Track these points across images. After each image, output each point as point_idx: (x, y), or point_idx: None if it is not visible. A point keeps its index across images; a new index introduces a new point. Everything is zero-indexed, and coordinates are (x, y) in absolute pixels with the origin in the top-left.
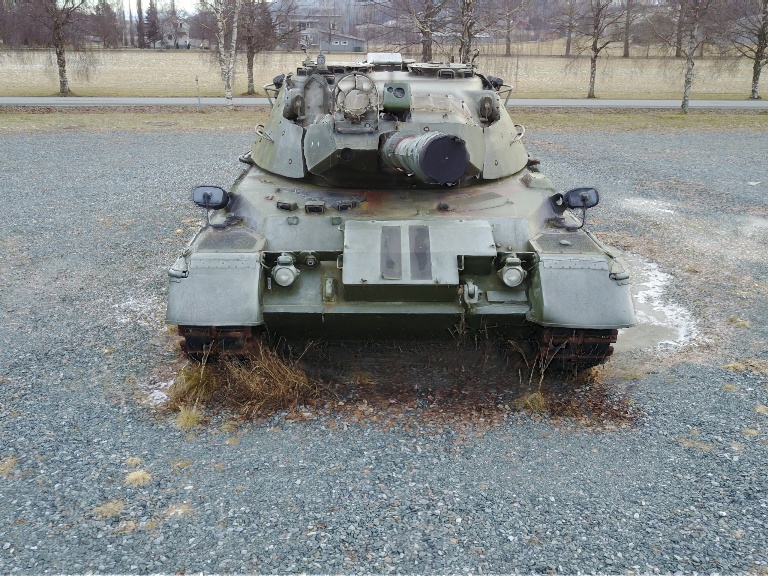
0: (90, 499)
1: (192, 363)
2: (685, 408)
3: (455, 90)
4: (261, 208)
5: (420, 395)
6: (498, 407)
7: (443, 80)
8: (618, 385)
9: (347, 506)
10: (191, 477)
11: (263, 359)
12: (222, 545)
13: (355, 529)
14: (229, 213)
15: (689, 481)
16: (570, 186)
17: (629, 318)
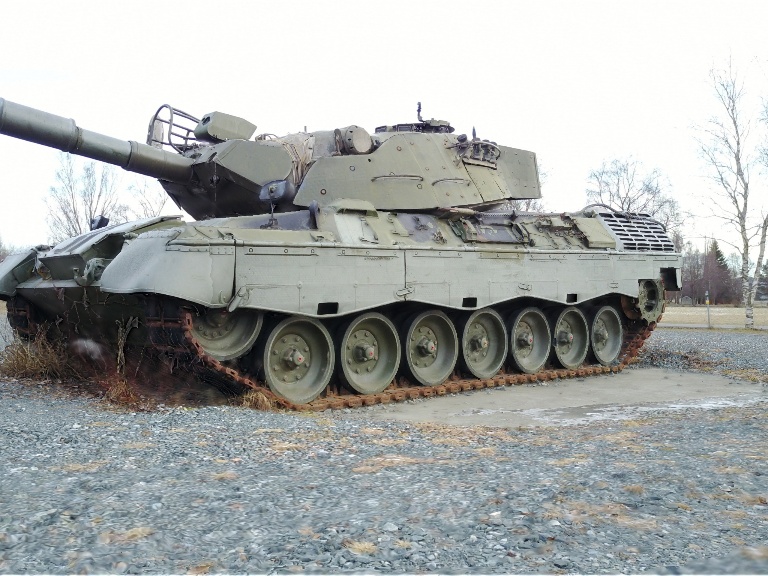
0: None
1: None
2: None
3: None
4: None
5: None
6: (99, 393)
7: None
8: None
9: None
10: None
11: (36, 339)
12: None
13: None
14: None
15: None
16: None
17: (148, 282)
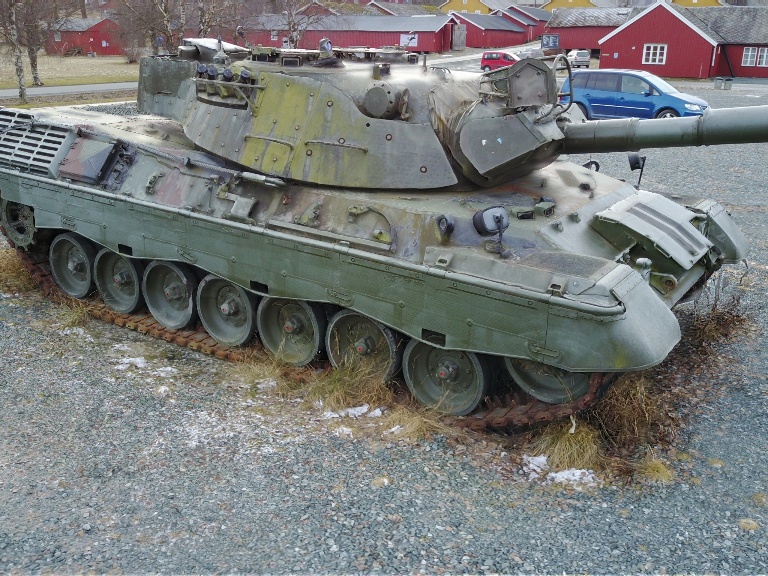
0: None
1: None
2: None
3: None
4: (514, 223)
5: None
6: None
7: (420, 65)
8: None
9: None
10: None
11: None
12: None
13: None
14: (497, 237)
15: None
16: None
17: None
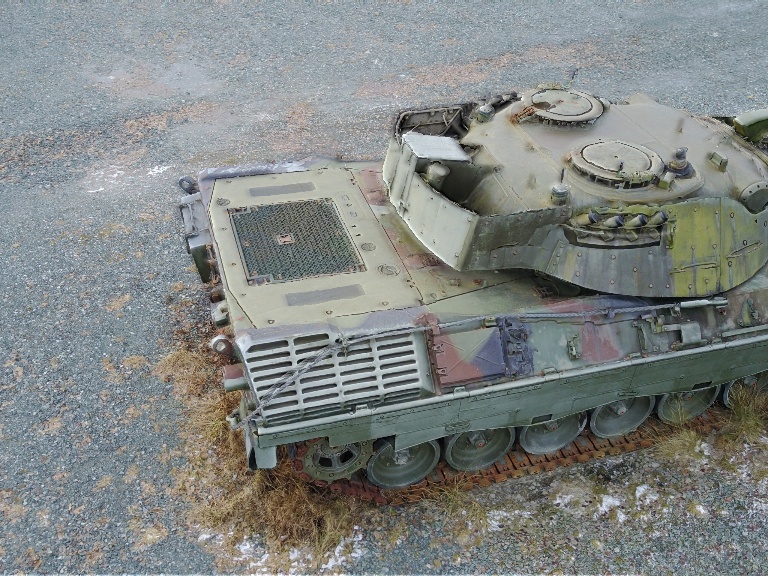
0: None
1: None
2: None
3: (664, 107)
4: None
5: None
6: None
7: (618, 110)
8: None
9: None
10: None
11: None
12: None
13: None
14: None
15: None
16: (5, 229)
17: None
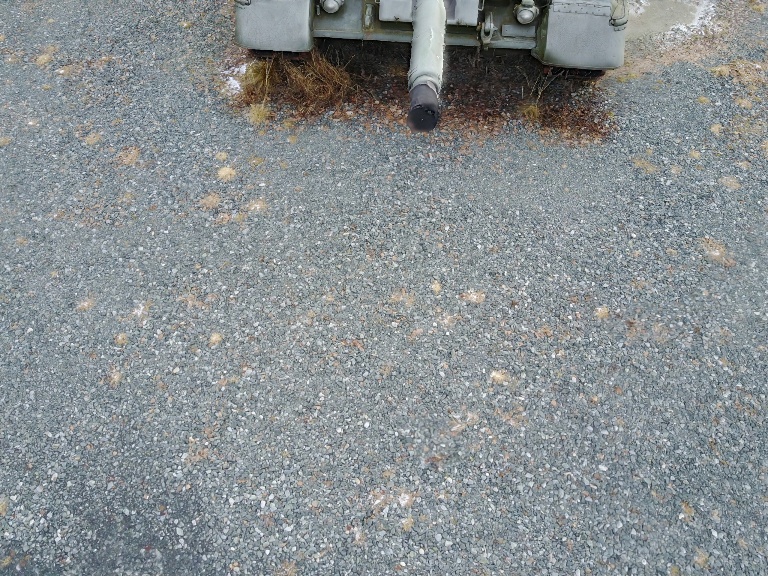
0: (196, 191)
1: (258, 61)
2: (654, 123)
3: None
4: None
5: (442, 93)
6: (501, 115)
7: None
8: (609, 90)
9: (372, 210)
10: (264, 174)
11: (315, 64)
12: (287, 238)
13: (376, 231)
14: None
15: (623, 203)
16: None
17: (617, 62)
